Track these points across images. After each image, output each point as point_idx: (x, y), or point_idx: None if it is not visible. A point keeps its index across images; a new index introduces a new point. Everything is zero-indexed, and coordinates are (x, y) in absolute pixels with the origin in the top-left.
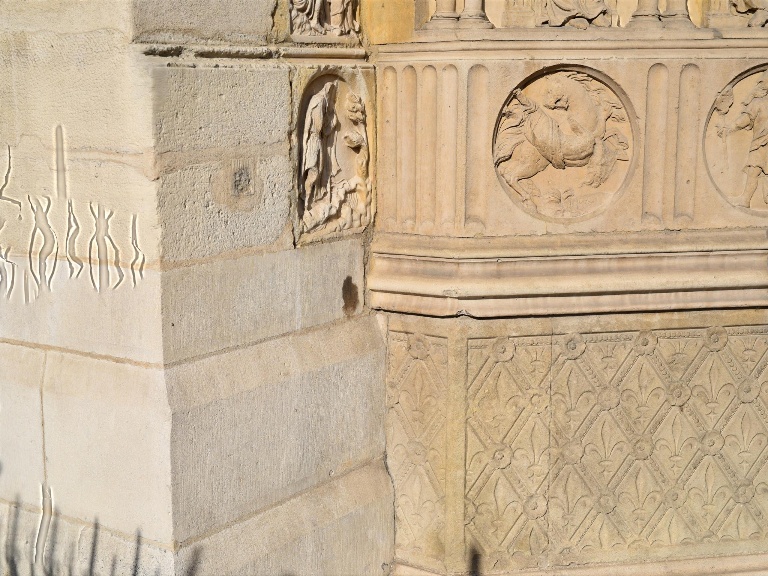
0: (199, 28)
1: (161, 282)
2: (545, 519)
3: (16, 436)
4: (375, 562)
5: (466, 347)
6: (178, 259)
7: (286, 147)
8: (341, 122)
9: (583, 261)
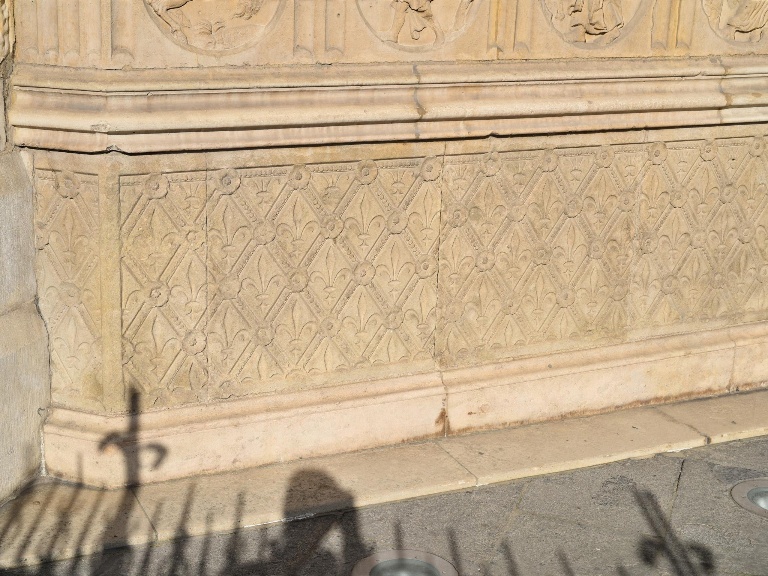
0: None
1: None
2: (204, 354)
3: None
4: (30, 407)
5: (118, 184)
6: None
7: None
8: None
9: (236, 95)
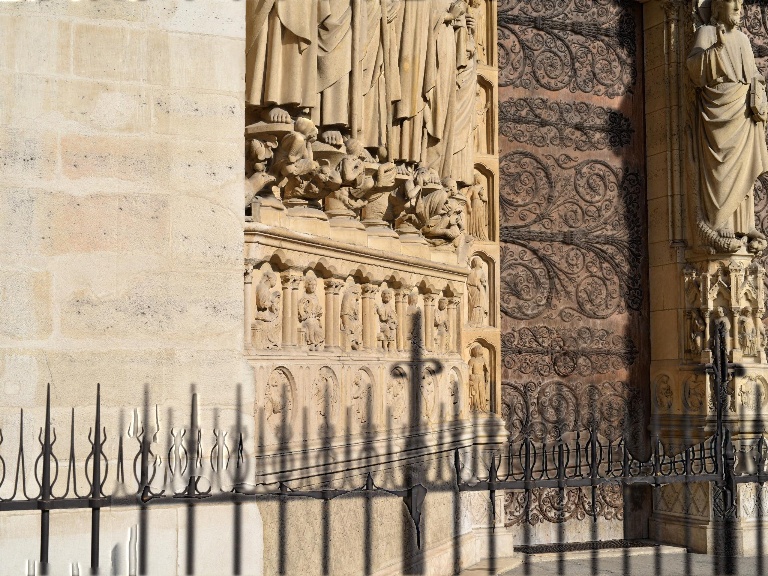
0: None
1: None
2: None
3: (156, 558)
4: None
5: None
6: None
7: None
8: None
9: None
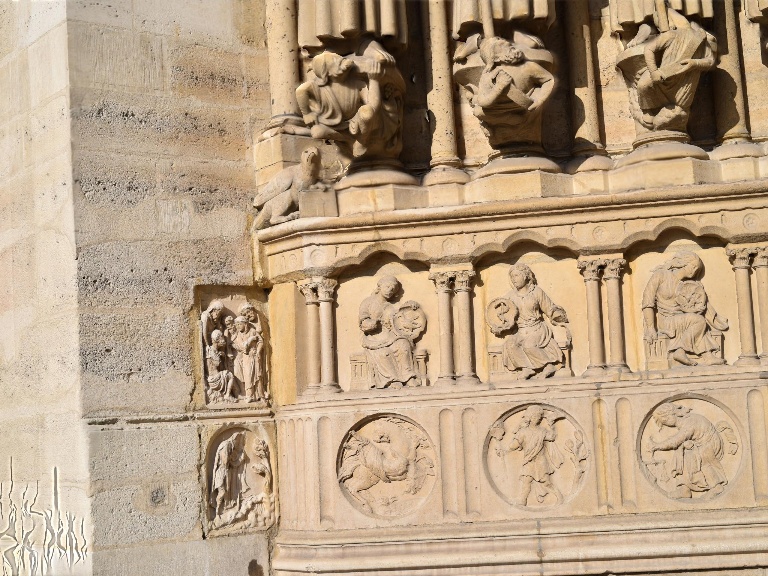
0: (132, 406)
1: (93, 558)
2: None
3: None
4: None
5: None
6: (107, 544)
7: (196, 475)
8: (251, 457)
9: (402, 546)
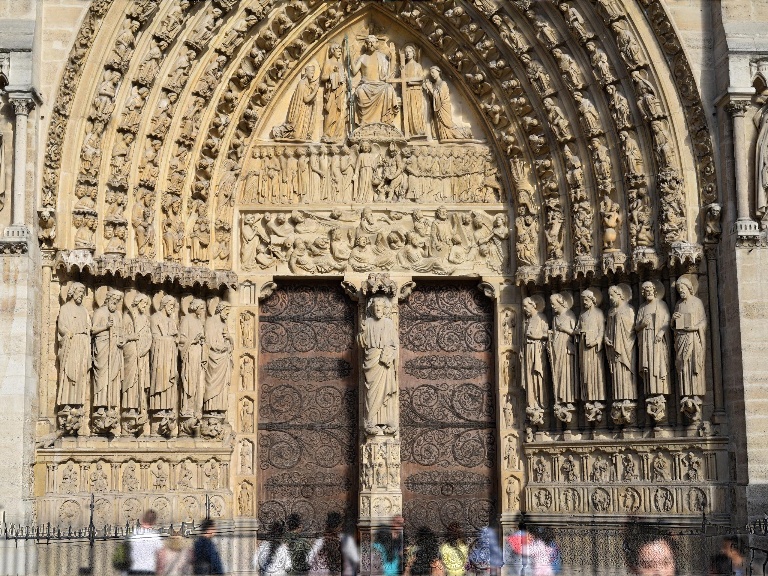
0: None
1: None
2: None
3: None
4: None
5: None
6: None
7: None
8: None
9: None
